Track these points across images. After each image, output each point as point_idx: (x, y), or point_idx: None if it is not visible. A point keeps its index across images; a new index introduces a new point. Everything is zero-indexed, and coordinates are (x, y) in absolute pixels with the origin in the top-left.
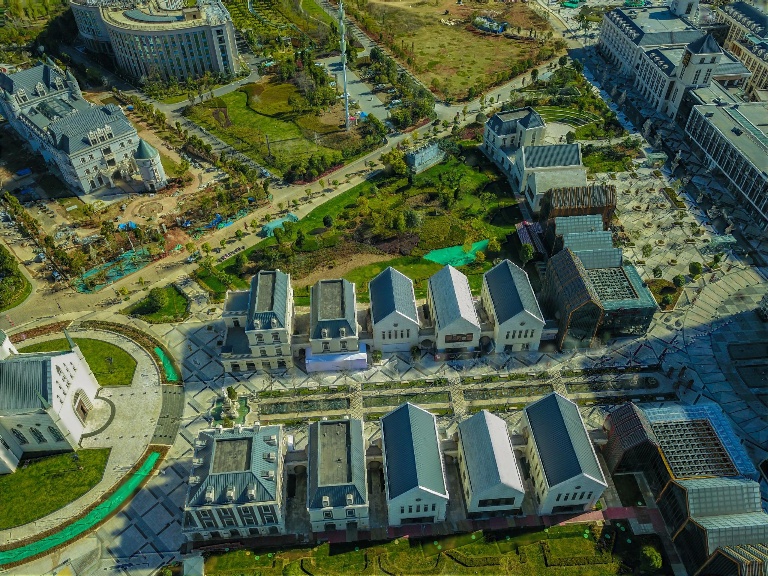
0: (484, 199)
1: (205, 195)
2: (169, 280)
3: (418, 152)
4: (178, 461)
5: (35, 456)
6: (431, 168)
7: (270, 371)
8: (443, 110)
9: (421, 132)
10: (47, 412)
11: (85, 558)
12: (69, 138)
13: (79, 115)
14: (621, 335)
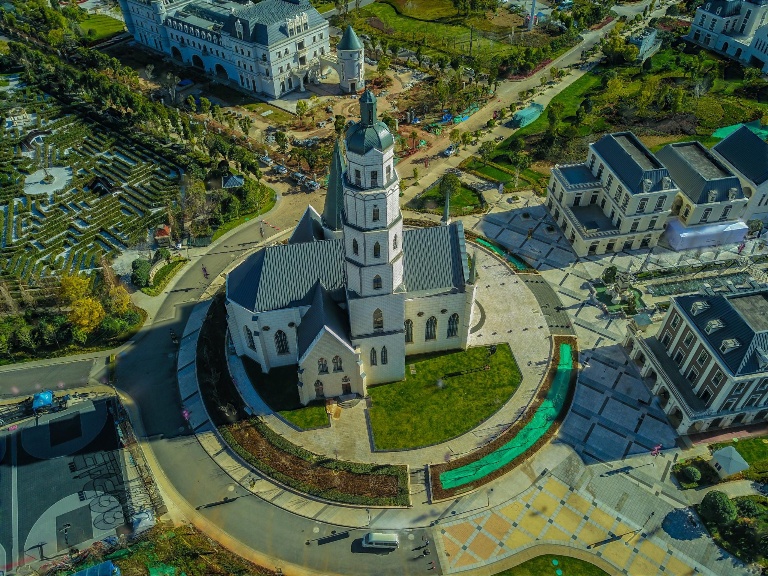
0: (754, 74)
1: (418, 93)
2: (437, 174)
3: (641, 38)
4: (596, 351)
5: (418, 359)
6: (653, 57)
7: (632, 252)
8: (619, 9)
9: (611, 28)
10: (473, 288)
11: (566, 466)
12: (267, 26)
13: (260, 6)
14: None
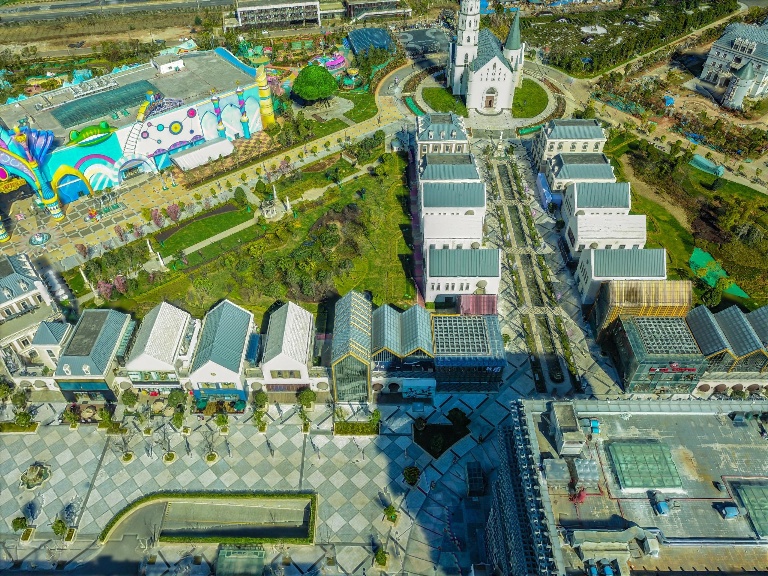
0: None
1: None
2: (615, 123)
3: None
4: None
5: (463, 98)
6: None
7: (534, 167)
8: None
9: None
10: (470, 72)
11: (408, 121)
12: (727, 33)
13: (765, 31)
14: (619, 371)
